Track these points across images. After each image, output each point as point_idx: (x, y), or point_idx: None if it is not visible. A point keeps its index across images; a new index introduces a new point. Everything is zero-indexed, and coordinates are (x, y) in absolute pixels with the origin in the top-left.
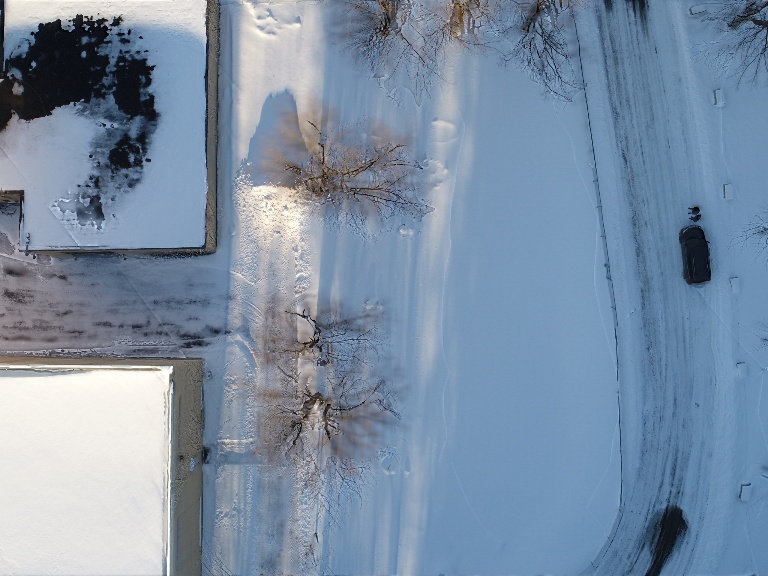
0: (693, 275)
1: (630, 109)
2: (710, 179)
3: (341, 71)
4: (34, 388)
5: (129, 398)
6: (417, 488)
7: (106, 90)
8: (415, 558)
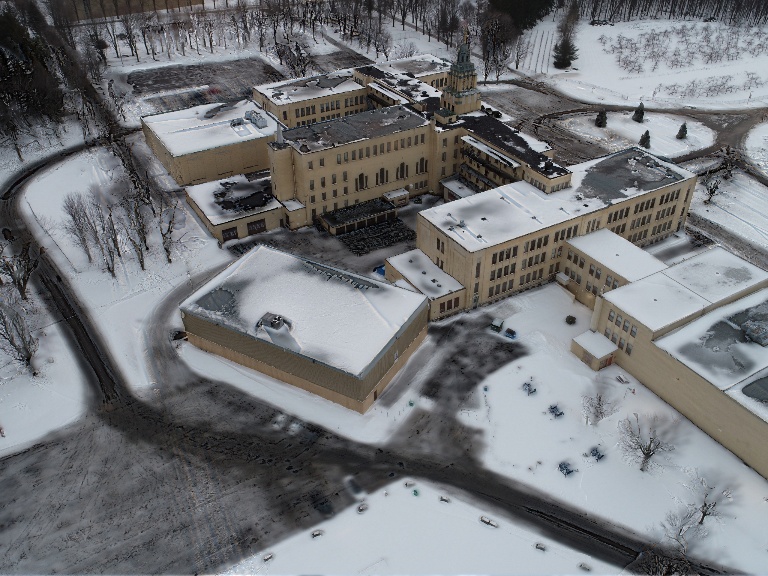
0: (9, 230)
1: (42, 258)
2: (6, 251)
3: (161, 238)
4: (213, 147)
5: (185, 152)
6: (96, 184)
7: (236, 202)
8: (92, 175)
